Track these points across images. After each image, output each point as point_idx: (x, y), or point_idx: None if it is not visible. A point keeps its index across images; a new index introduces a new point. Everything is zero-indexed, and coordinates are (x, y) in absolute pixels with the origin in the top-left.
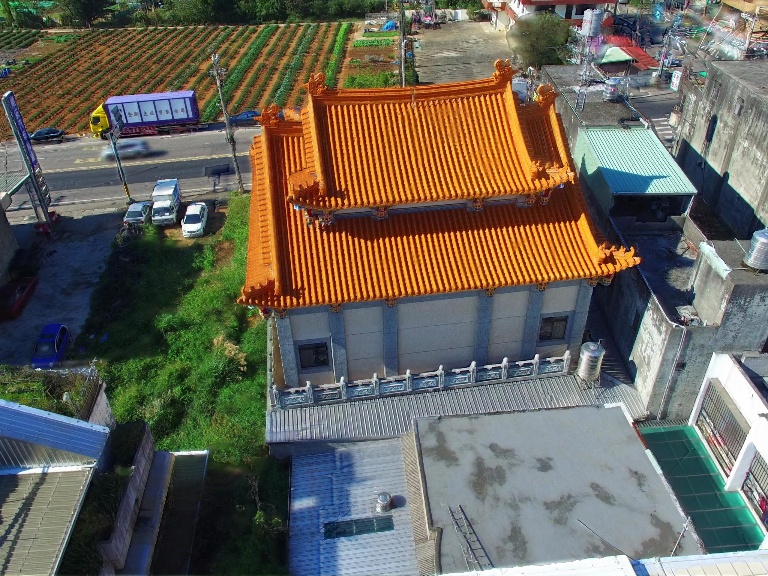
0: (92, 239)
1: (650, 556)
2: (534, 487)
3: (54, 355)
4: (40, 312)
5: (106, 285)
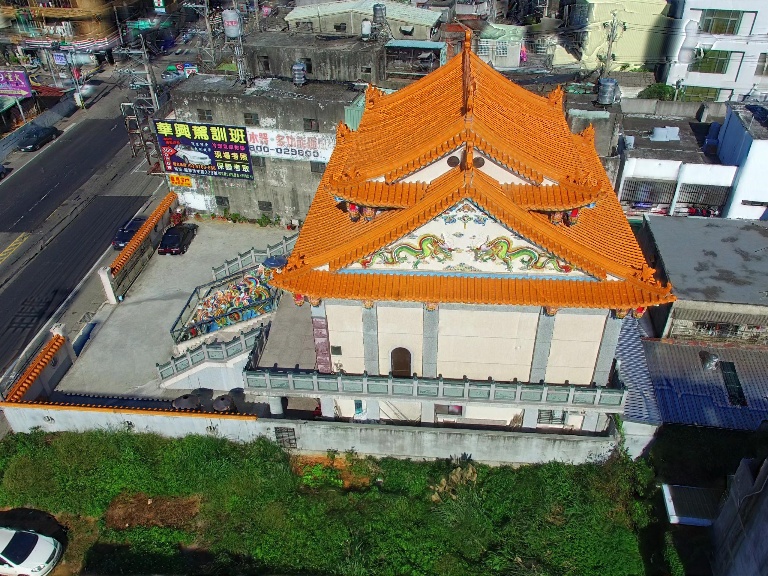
0: None
1: None
2: (733, 261)
3: None
4: None
5: None
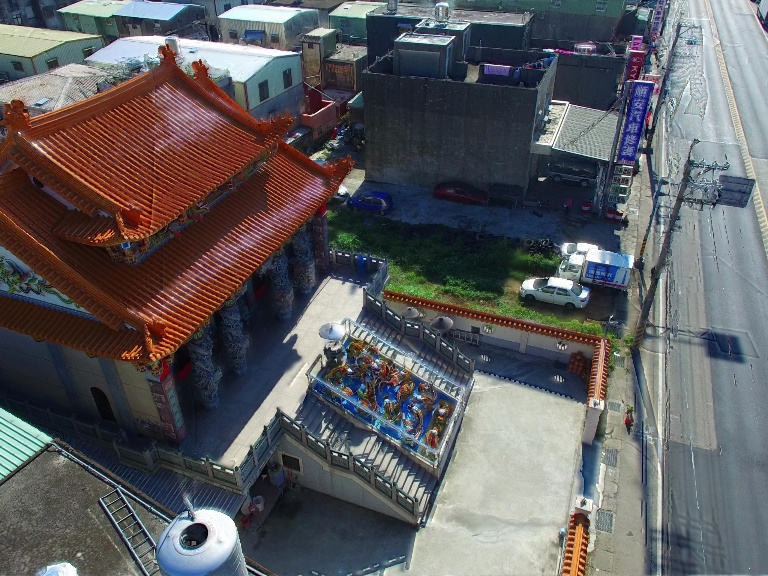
0: (557, 235)
1: None
2: None
3: None
4: (437, 206)
5: None
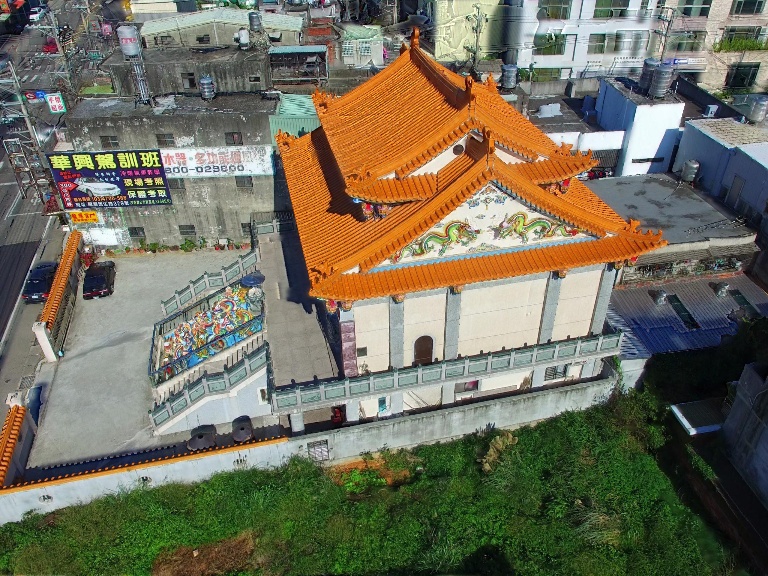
0: None
1: (670, 185)
2: (652, 210)
3: None
4: None
5: None
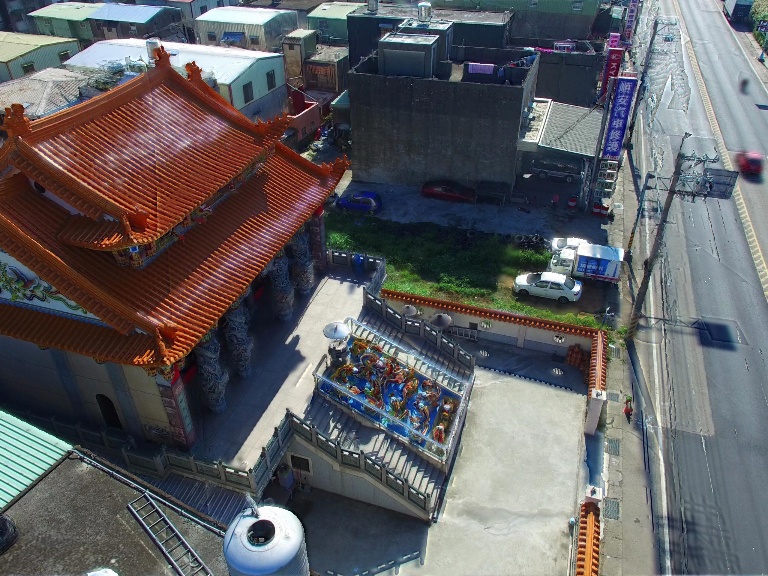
0: (545, 230)
1: None
2: None
3: (346, 201)
4: (425, 205)
5: (431, 224)
